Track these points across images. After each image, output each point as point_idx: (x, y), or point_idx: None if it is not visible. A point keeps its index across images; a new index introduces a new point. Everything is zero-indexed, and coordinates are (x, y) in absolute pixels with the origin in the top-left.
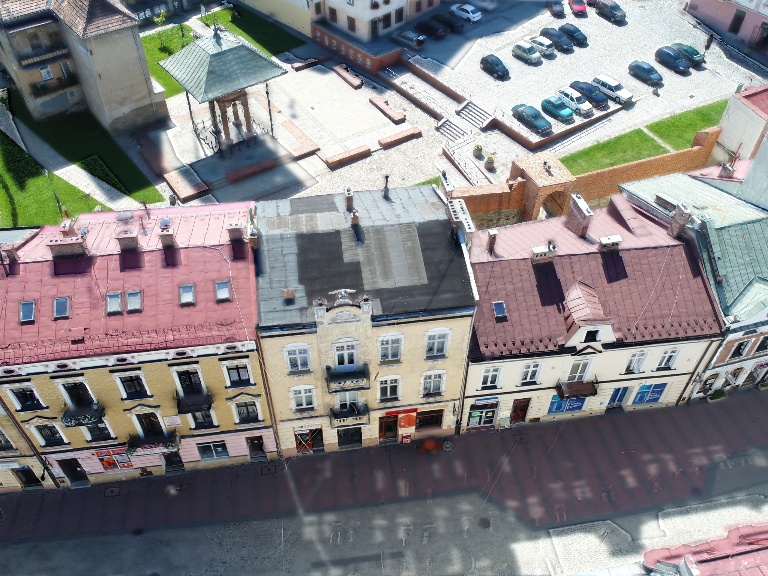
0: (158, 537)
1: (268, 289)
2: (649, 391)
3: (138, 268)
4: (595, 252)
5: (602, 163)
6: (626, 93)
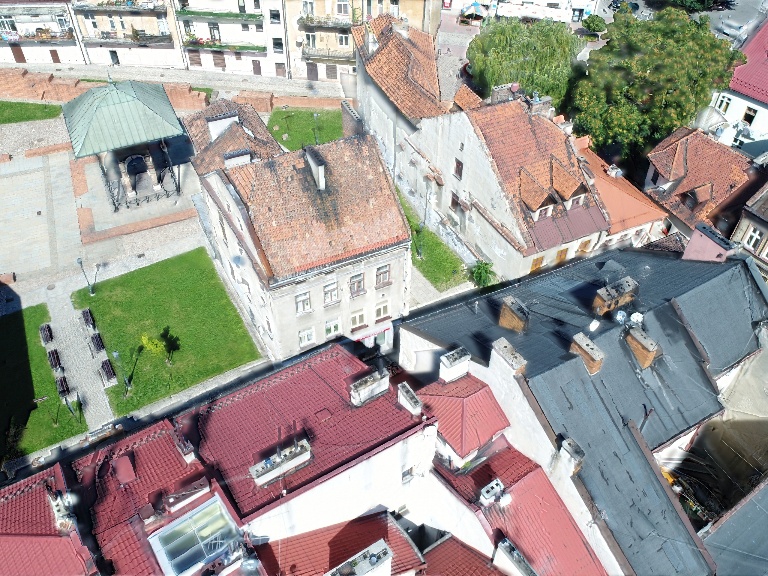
0: None
1: None
2: None
3: None
4: None
5: None
6: None
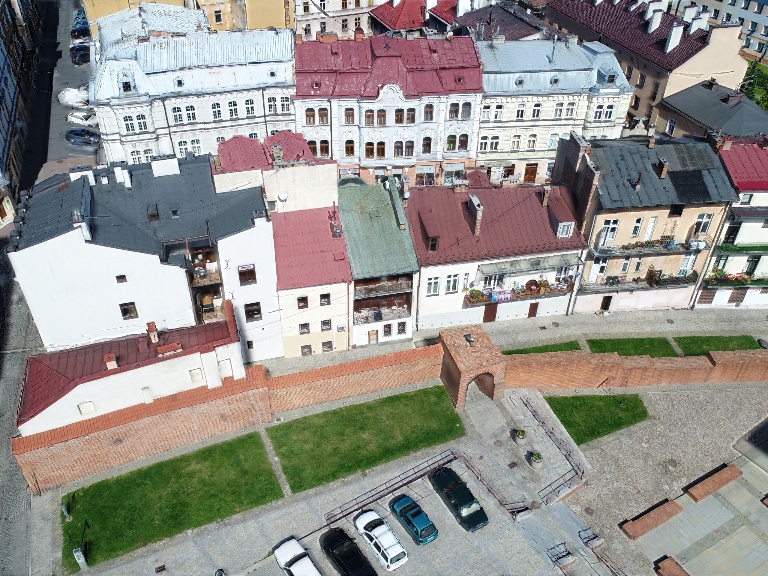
0: None
1: (688, 139)
2: None
3: None
4: (471, 189)
5: (374, 431)
6: (287, 552)
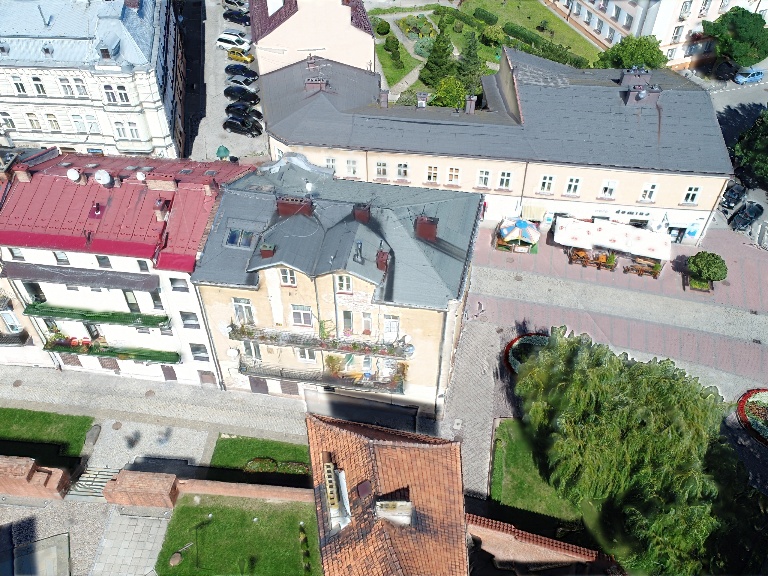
0: None
1: None
2: None
3: None
4: None
5: None
6: None
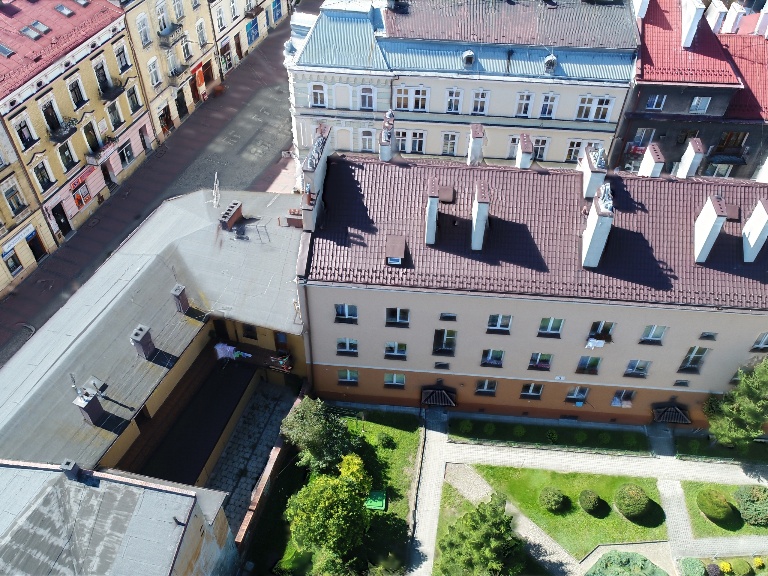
0: (152, 209)
1: None
2: (276, 8)
3: (19, 12)
4: None
5: None
6: None
